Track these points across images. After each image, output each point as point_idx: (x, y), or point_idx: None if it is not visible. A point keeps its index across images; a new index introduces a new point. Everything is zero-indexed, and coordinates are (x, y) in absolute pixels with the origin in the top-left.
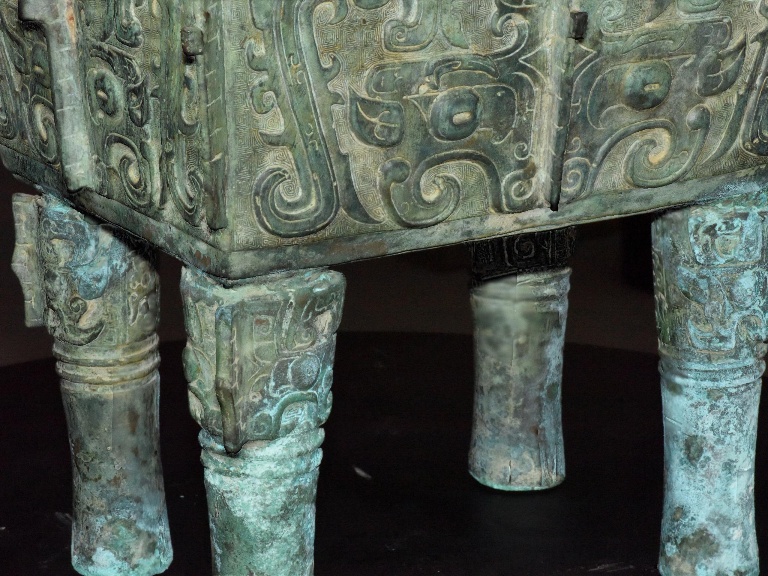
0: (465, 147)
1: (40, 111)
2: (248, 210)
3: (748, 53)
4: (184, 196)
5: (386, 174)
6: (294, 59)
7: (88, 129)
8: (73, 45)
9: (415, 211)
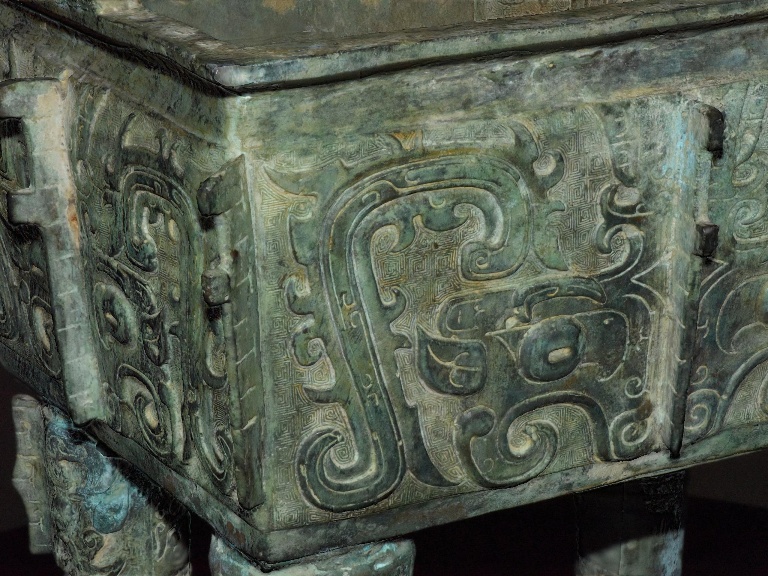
0: (563, 388)
1: (42, 314)
2: (291, 481)
3: None
4: (212, 456)
5: (464, 427)
6: (347, 298)
7: (97, 352)
8: (77, 251)
9: (501, 468)
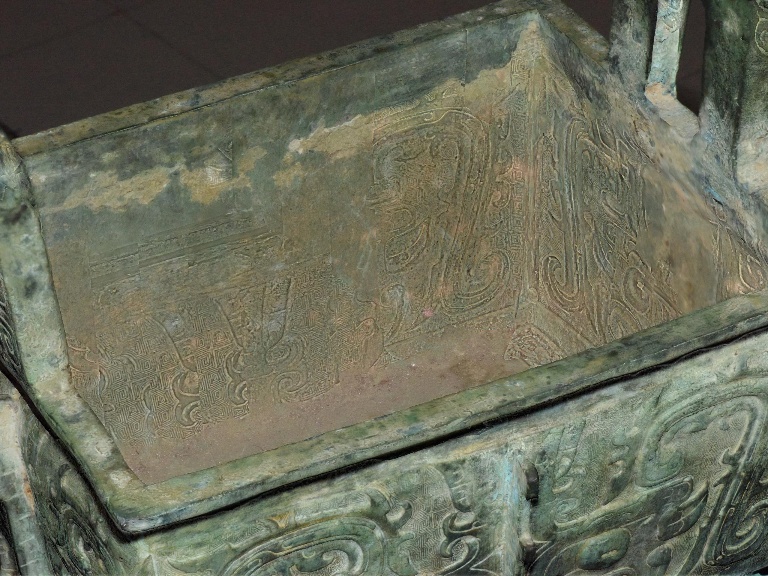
0: None
1: None
2: None
3: (711, 494)
4: None
5: None
6: None
7: None
8: (32, 512)
9: None
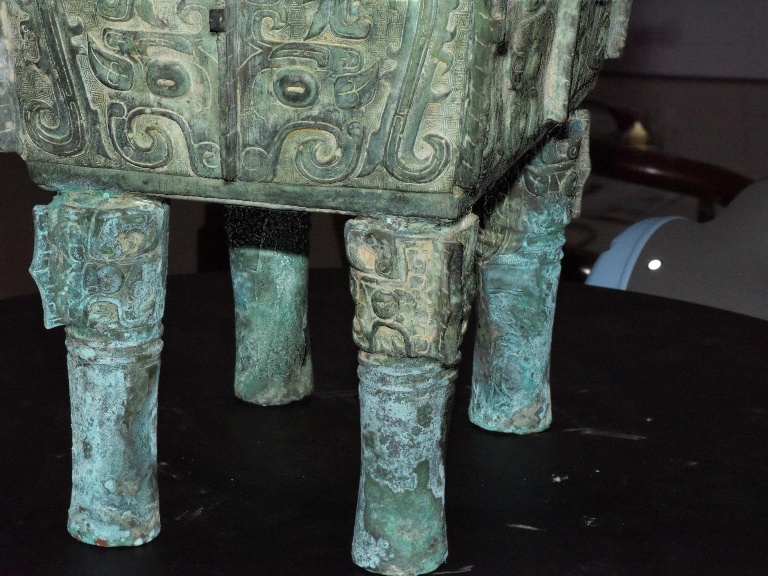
0: None
1: None
2: None
3: None
4: None
5: None
6: None
7: None
8: None
9: None
